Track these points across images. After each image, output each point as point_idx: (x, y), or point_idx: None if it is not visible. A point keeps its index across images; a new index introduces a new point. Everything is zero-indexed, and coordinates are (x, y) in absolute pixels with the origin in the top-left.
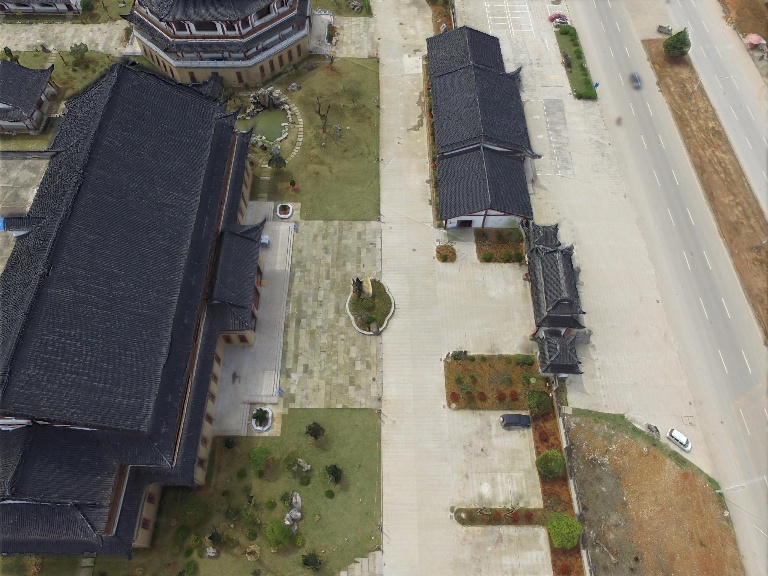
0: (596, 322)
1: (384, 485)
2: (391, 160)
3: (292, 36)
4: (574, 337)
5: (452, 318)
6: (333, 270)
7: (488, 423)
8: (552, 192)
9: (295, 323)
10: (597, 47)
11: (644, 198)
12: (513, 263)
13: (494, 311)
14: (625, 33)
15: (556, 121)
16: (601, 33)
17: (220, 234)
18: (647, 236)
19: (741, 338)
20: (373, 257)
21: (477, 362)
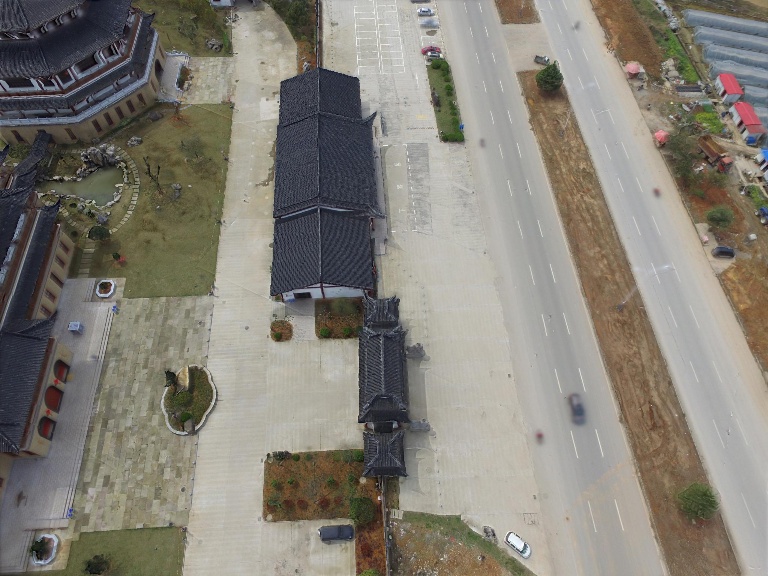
0: (439, 404)
1: None
2: (234, 221)
3: (128, 86)
4: (398, 435)
5: (280, 409)
6: (153, 357)
7: (307, 537)
8: (406, 251)
9: (101, 425)
10: (470, 82)
11: (505, 254)
12: (355, 338)
13: (328, 397)
14: (501, 65)
15: (418, 168)
16: (475, 66)
17: None
18: (504, 298)
19: (595, 415)
20: (200, 339)
21: (302, 461)
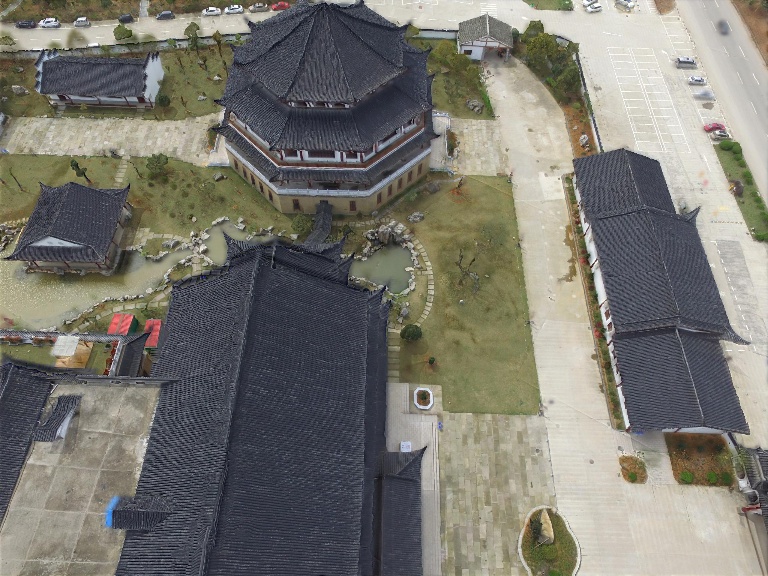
0: None
1: None
2: (544, 323)
3: (416, 156)
4: None
5: (657, 573)
6: (494, 491)
7: None
8: (751, 377)
9: (455, 575)
10: (767, 169)
11: None
12: (721, 487)
13: (709, 563)
14: None
15: (737, 272)
16: None
17: (377, 482)
18: None
19: None
20: (542, 472)
21: None
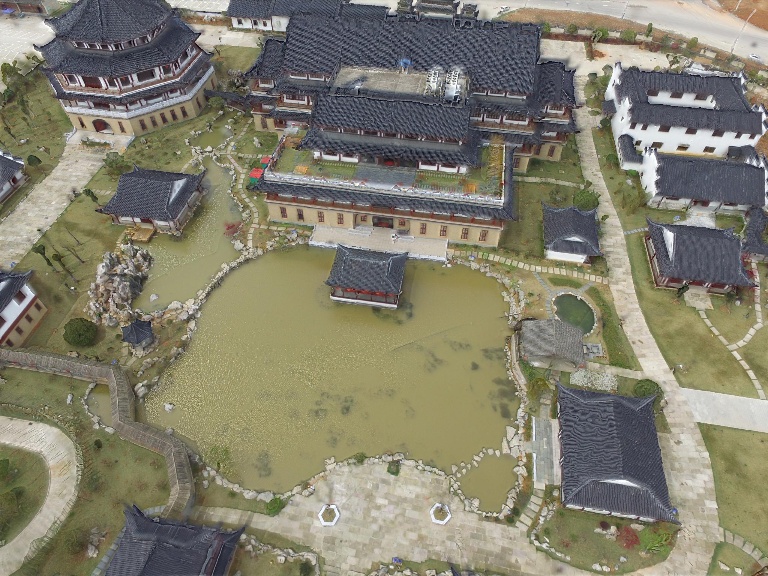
0: None
1: None
2: None
3: None
4: (464, 4)
5: None
6: None
7: None
8: None
9: None
10: None
11: None
12: None
13: None
14: None
15: None
16: None
17: None
18: None
19: None
20: None
21: None
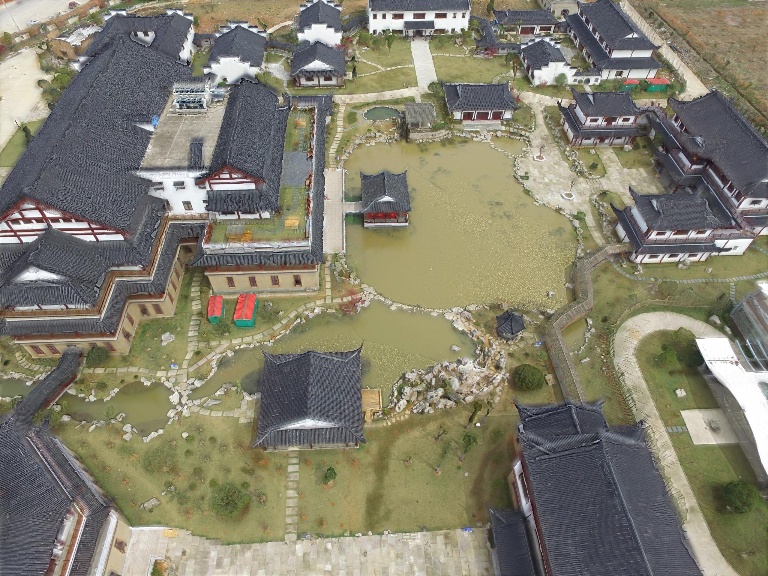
0: None
1: (8, 141)
2: None
3: None
4: None
5: None
6: None
7: None
8: None
9: None
10: None
11: None
12: None
13: None
14: None
15: None
16: None
17: None
18: None
19: None
20: None
21: None
